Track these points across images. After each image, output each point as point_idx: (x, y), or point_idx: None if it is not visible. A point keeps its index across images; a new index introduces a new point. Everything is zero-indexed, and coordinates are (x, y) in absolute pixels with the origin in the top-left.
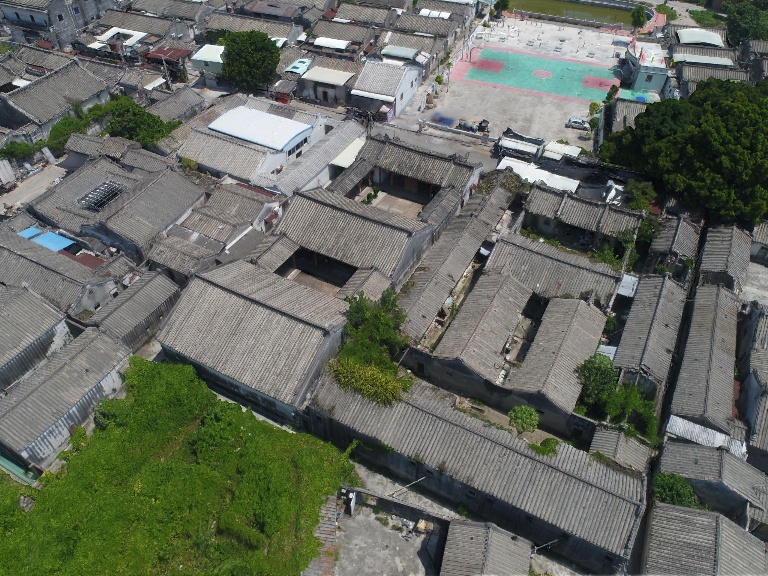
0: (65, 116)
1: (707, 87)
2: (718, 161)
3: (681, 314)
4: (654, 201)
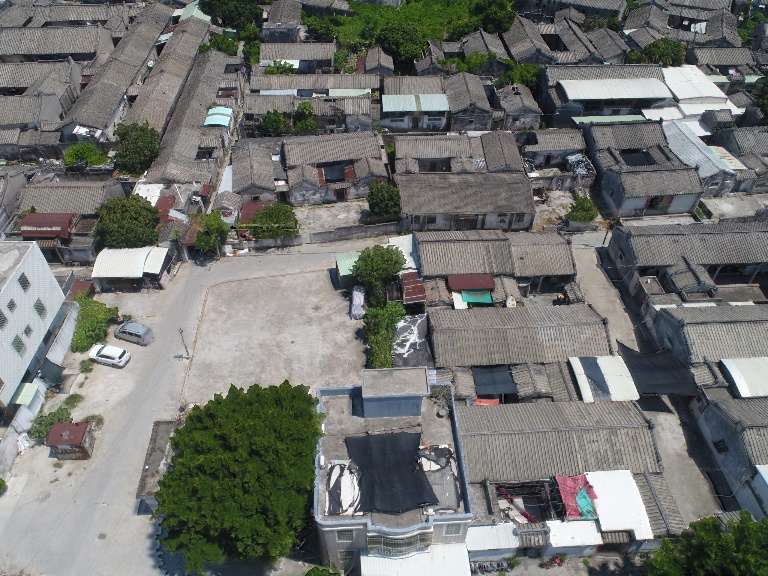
0: None
1: None
2: None
3: None
4: None
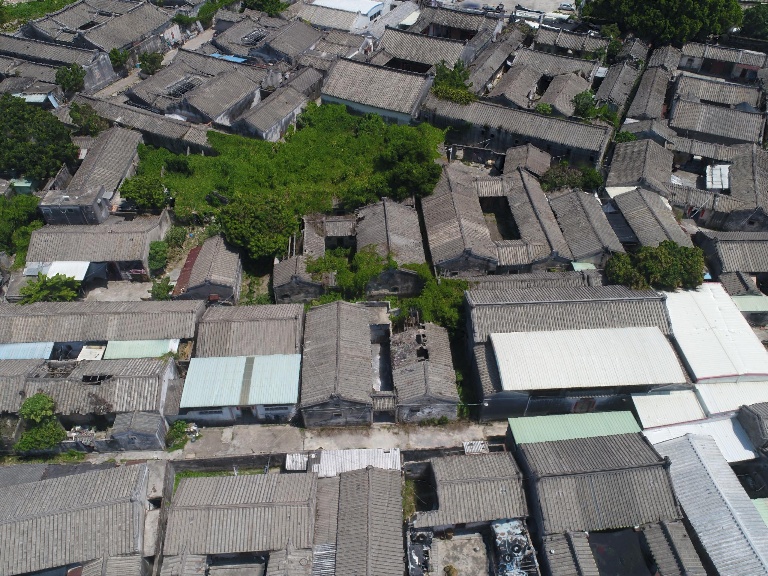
0: (208, 1)
1: None
2: (658, 2)
3: None
4: (619, 37)
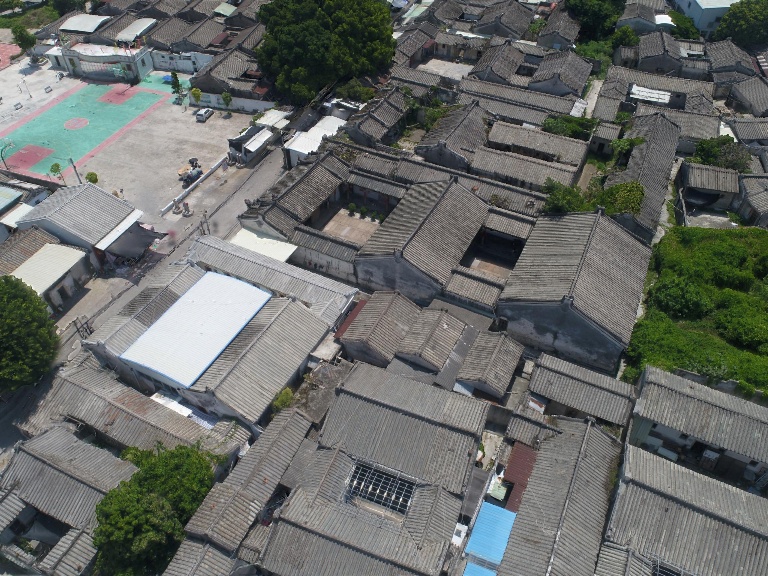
0: None
1: (276, 11)
2: (367, 34)
3: None
4: None
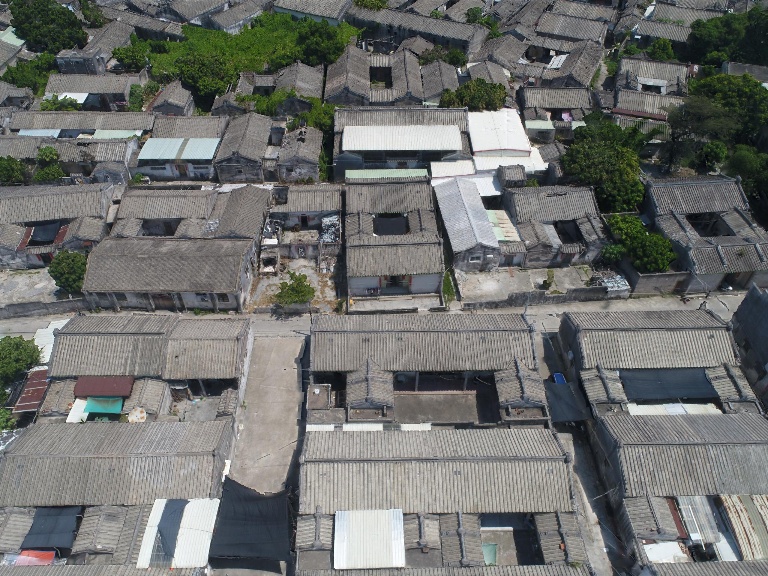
0: None
1: None
2: None
3: (522, 3)
4: None
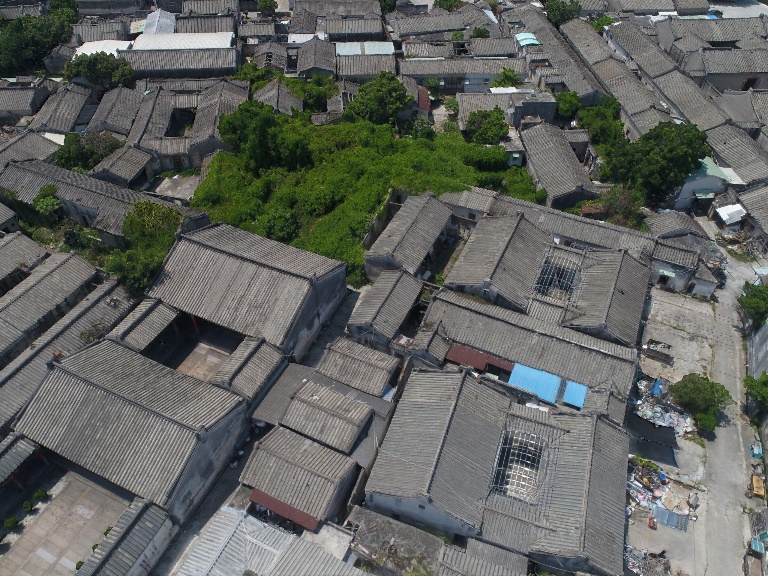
0: None
1: None
2: None
3: None
4: None
